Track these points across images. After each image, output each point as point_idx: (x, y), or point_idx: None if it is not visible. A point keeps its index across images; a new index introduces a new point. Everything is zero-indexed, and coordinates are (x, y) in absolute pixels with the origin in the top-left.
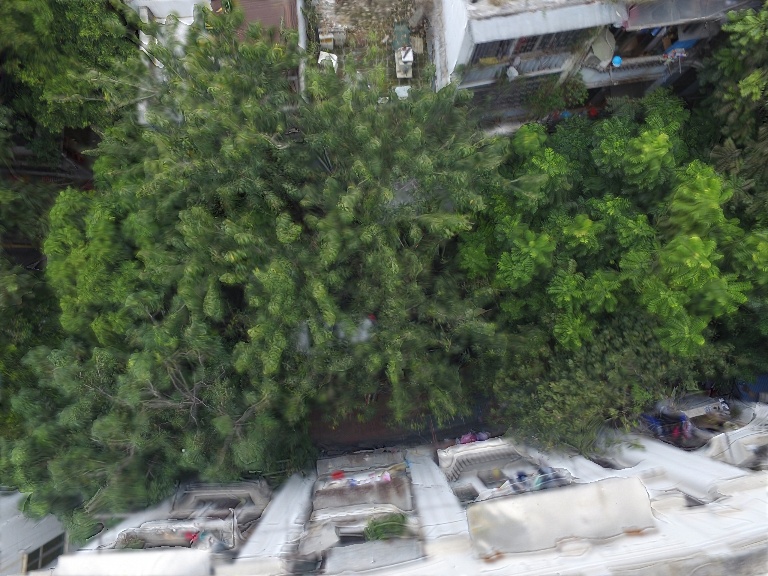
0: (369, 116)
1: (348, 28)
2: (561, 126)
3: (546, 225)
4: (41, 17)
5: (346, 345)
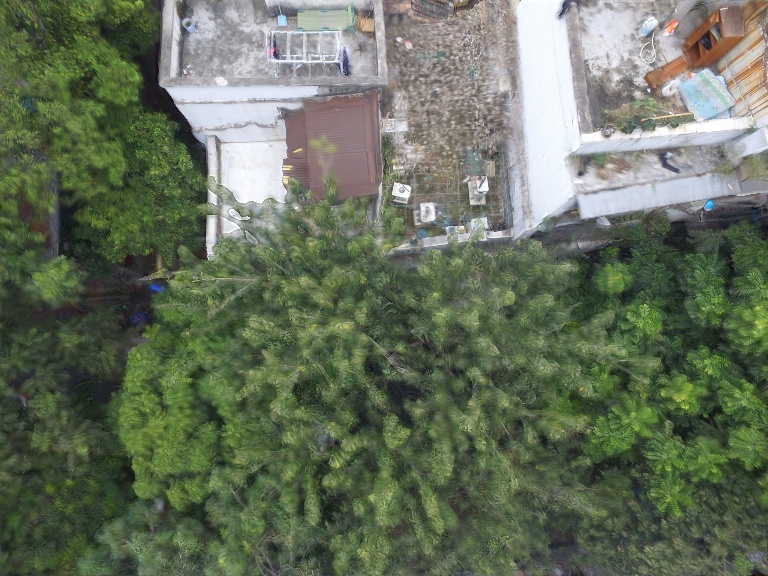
0: (483, 314)
1: (429, 168)
2: (636, 251)
3: None
4: (117, 168)
5: None
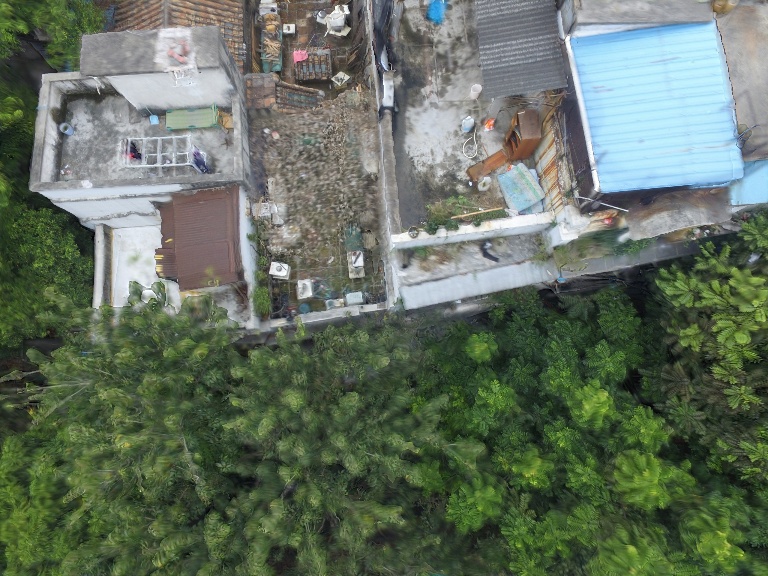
0: None
1: (294, 252)
2: (517, 315)
3: (500, 440)
4: None
5: None
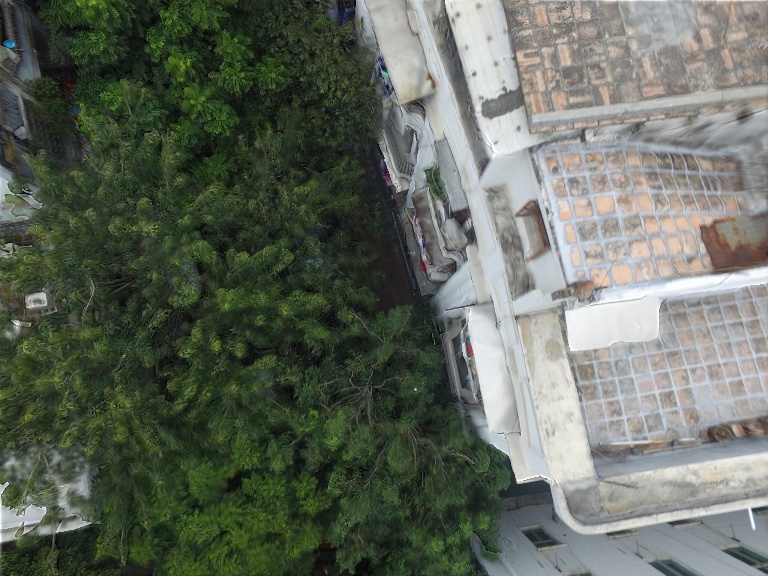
0: (62, 226)
1: None
2: None
3: None
4: None
5: (302, 254)
